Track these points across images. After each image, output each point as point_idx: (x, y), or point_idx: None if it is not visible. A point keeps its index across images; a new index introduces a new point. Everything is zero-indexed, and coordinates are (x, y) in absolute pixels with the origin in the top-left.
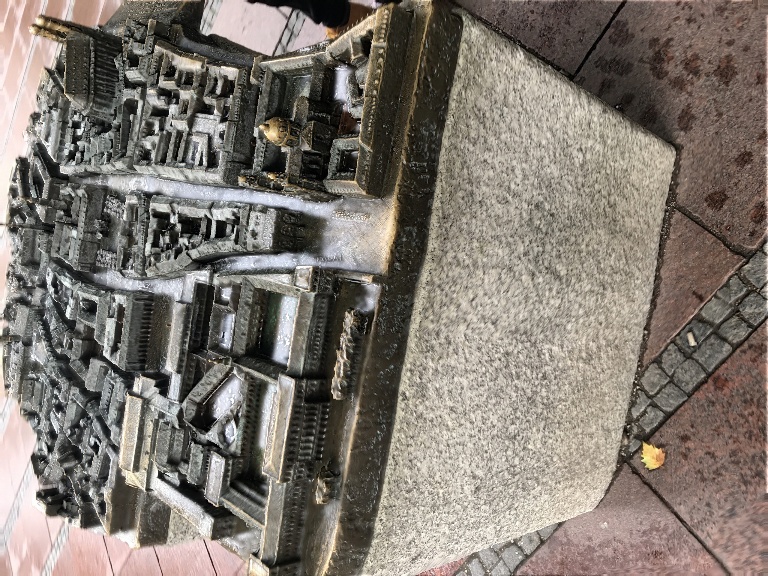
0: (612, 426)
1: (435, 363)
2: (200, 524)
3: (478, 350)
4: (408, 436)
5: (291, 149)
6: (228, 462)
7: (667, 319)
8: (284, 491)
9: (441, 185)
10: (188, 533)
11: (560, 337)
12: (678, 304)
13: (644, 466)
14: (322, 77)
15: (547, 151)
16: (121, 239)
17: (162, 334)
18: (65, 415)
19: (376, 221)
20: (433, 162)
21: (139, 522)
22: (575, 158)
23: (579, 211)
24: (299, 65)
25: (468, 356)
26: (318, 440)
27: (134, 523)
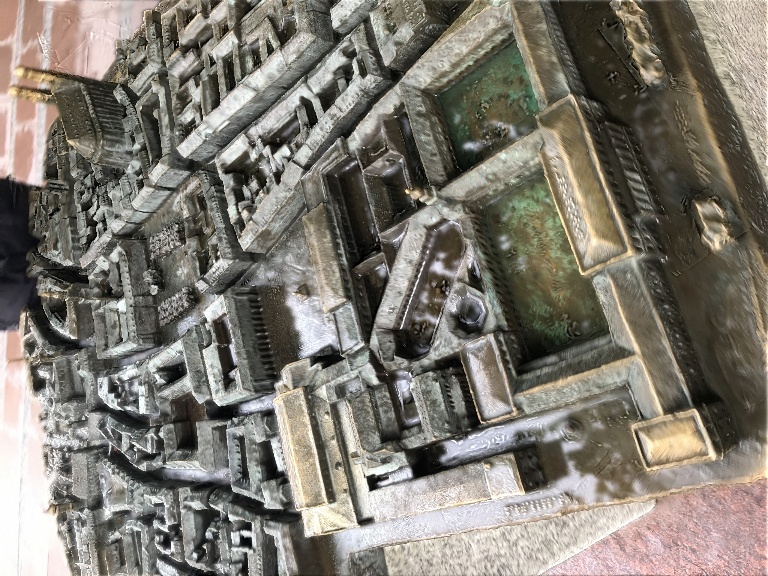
0: None
1: (733, 46)
2: (489, 484)
3: None
4: None
5: None
6: (498, 339)
7: None
8: (639, 278)
9: None
10: None
11: None
12: None
13: None
14: None
15: None
16: (189, 243)
17: (287, 323)
18: (180, 541)
19: None
20: None
21: None
22: None
23: None
24: None
25: None
26: (646, 183)
27: None
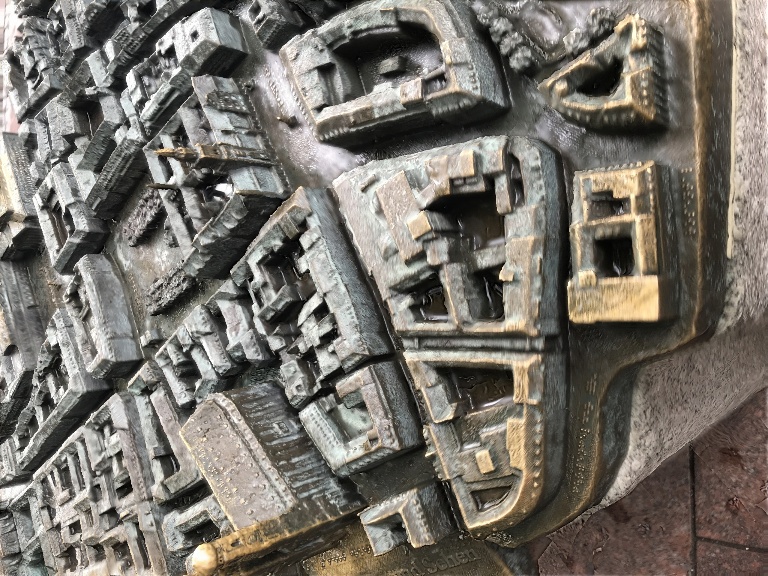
0: None
1: None
2: None
3: None
4: None
5: None
6: None
7: None
8: None
9: None
10: None
11: None
12: None
13: None
14: None
15: None
16: None
17: None
18: None
19: None
20: None
21: None
22: None
23: None
24: None
25: None
26: None
27: None
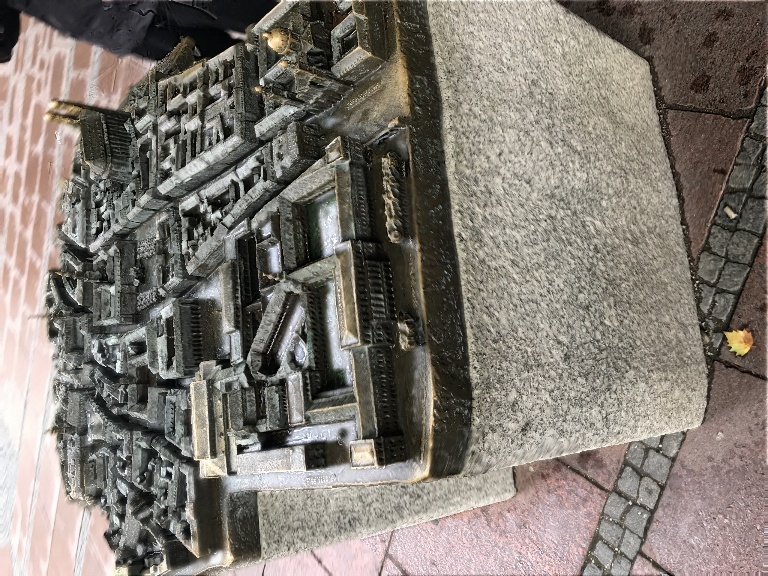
0: (686, 320)
1: (482, 209)
2: (291, 462)
3: (521, 206)
4: (477, 280)
5: (296, 56)
6: (305, 375)
7: (699, 206)
8: (367, 358)
9: (438, 44)
10: (282, 543)
11: (599, 213)
12: (704, 187)
13: (735, 355)
14: (308, 2)
15: (526, 36)
16: (158, 259)
17: (213, 329)
18: (131, 468)
19: (388, 81)
20: (425, 26)
21: (228, 532)
22: (555, 48)
23: (575, 96)
24: (286, 8)
25: (513, 211)
26: (388, 299)
27: (223, 537)
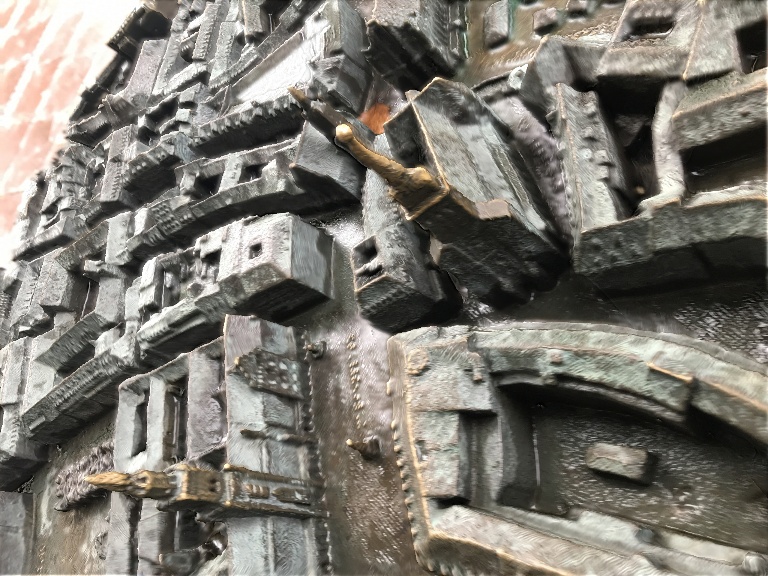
0: None
1: None
2: None
3: None
4: None
5: None
6: None
7: None
8: None
9: None
10: None
11: None
12: None
13: None
14: None
15: None
16: None
17: None
18: None
19: None
20: None
21: None
22: None
23: None
24: None
25: None
26: None
27: None
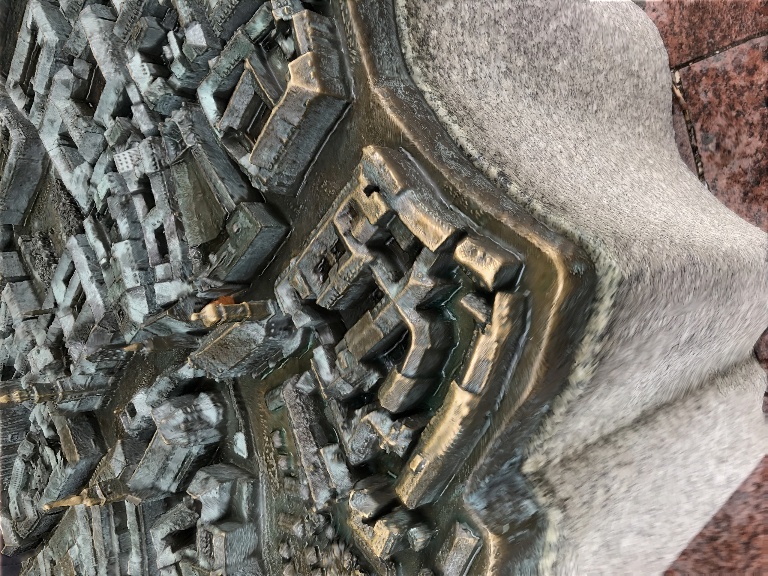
0: None
1: None
2: None
3: None
4: None
5: None
6: None
7: None
8: None
9: None
10: None
11: None
12: None
13: None
14: None
15: None
16: None
17: None
18: None
19: None
20: None
21: None
22: None
23: None
24: None
25: None
26: None
27: None
